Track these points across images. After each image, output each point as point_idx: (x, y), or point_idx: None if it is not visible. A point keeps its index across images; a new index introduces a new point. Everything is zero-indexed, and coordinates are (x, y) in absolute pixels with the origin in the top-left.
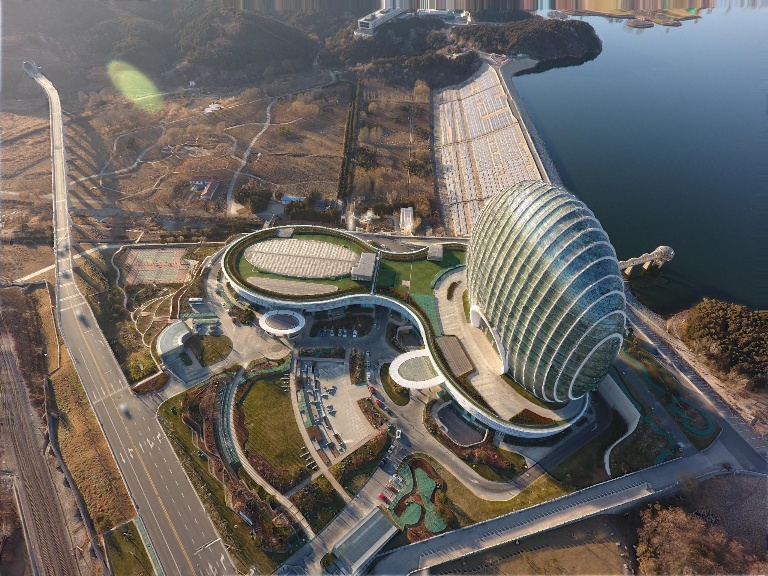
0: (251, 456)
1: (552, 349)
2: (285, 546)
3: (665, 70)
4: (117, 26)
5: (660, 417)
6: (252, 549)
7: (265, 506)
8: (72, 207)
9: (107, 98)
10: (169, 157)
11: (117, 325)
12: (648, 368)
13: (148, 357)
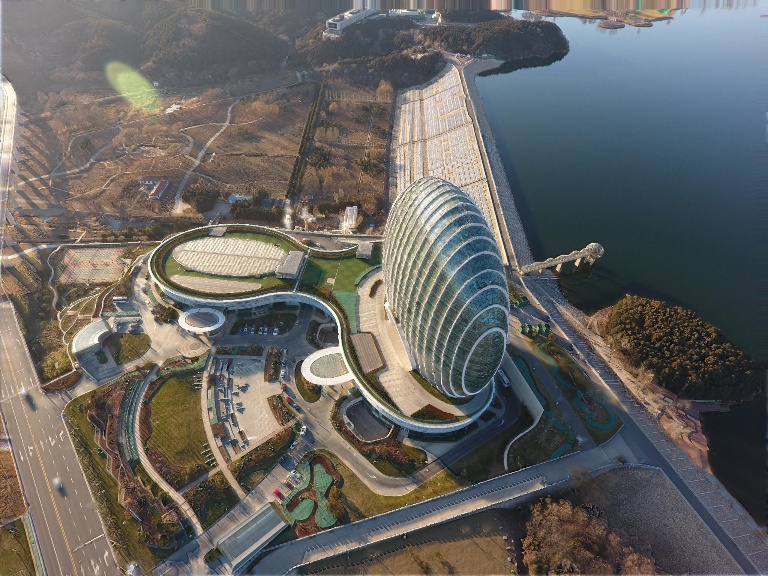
0: (151, 453)
1: (442, 344)
2: (170, 542)
3: (622, 70)
4: (84, 27)
5: (564, 412)
6: (137, 545)
7: (156, 502)
8: (18, 207)
9: (68, 99)
10: (123, 157)
11: (41, 324)
12: (559, 363)
13: (65, 355)
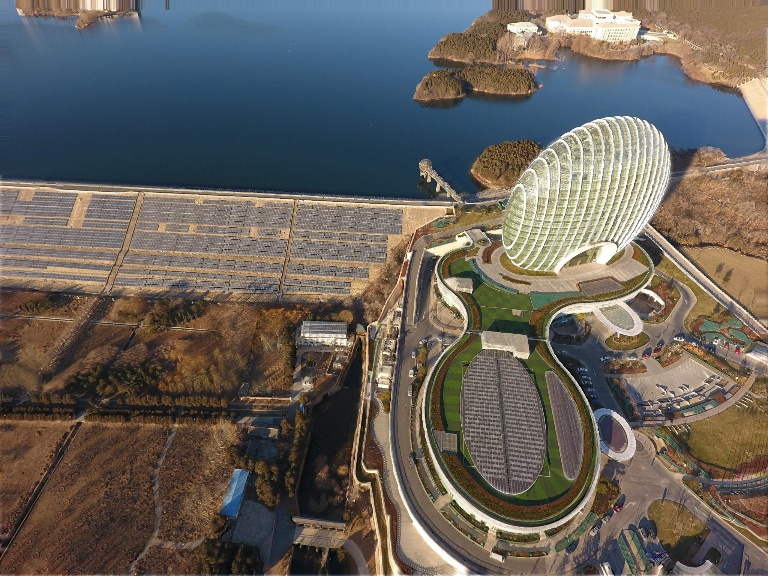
0: None
1: None
2: None
3: (109, 74)
4: None
5: None
6: None
7: None
8: None
9: None
10: None
11: None
12: None
13: None
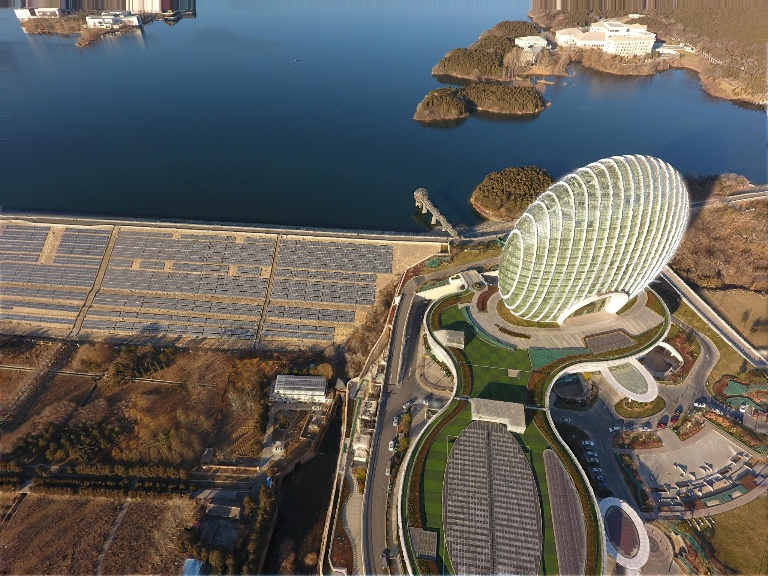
0: None
1: None
2: None
3: (97, 96)
4: None
5: None
6: None
7: None
8: None
9: None
10: None
11: None
12: None
13: None
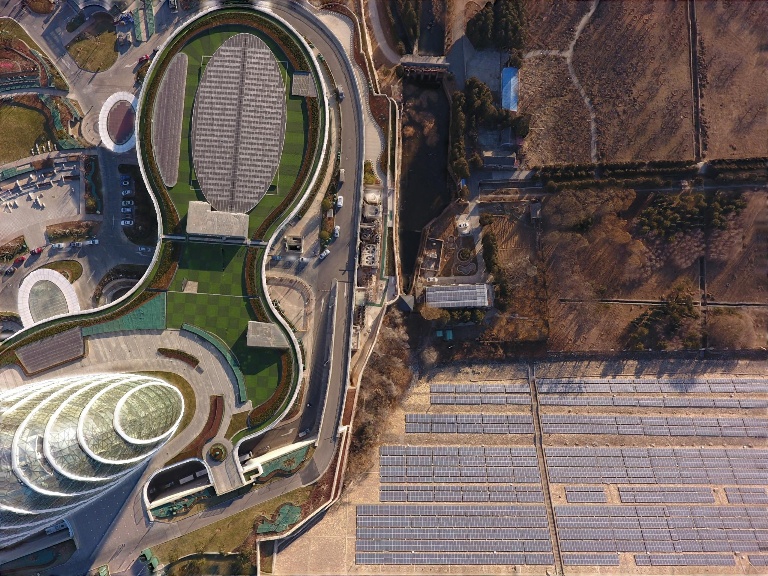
0: None
1: None
2: None
3: None
4: None
5: None
6: None
7: None
8: None
9: None
10: None
11: None
12: None
13: None
